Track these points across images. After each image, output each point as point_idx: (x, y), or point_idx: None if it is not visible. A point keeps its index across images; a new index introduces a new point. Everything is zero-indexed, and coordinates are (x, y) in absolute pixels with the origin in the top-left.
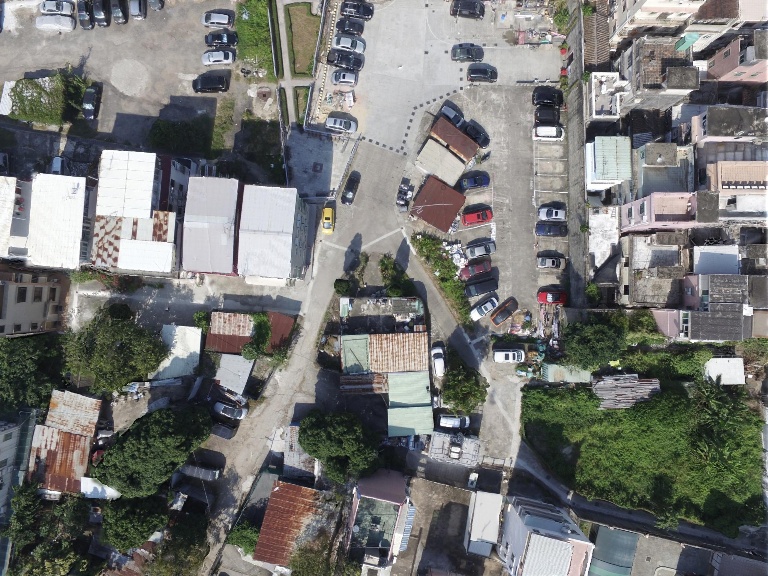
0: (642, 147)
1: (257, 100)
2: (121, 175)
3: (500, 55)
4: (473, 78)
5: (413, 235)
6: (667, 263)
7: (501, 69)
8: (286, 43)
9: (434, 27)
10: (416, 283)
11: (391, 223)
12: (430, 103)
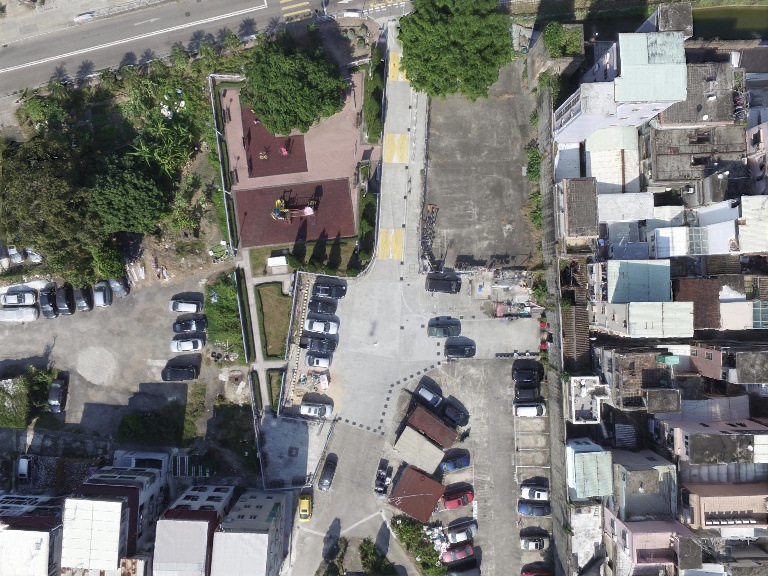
0: (623, 469)
1: (229, 384)
2: (86, 526)
3: (478, 327)
4: (450, 357)
5: (393, 519)
6: (651, 570)
7: (479, 342)
8: (257, 324)
9: (409, 301)
10: (397, 567)
11: (370, 506)
12: (407, 380)
